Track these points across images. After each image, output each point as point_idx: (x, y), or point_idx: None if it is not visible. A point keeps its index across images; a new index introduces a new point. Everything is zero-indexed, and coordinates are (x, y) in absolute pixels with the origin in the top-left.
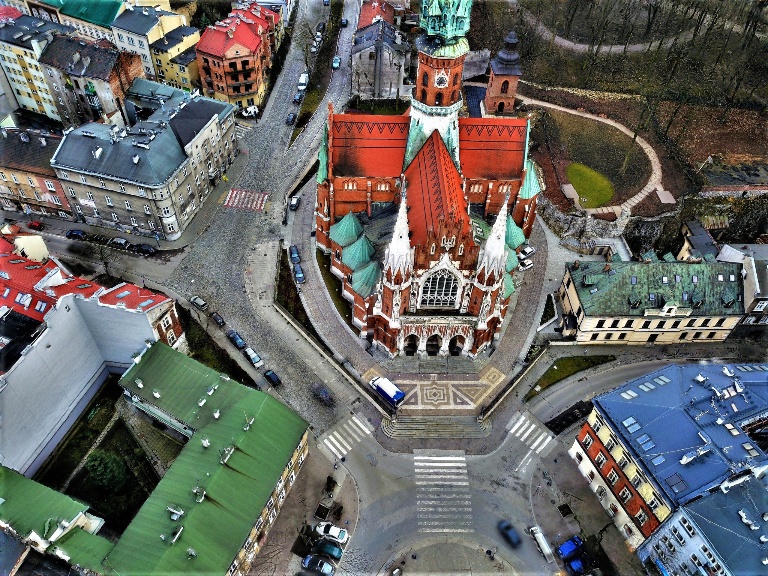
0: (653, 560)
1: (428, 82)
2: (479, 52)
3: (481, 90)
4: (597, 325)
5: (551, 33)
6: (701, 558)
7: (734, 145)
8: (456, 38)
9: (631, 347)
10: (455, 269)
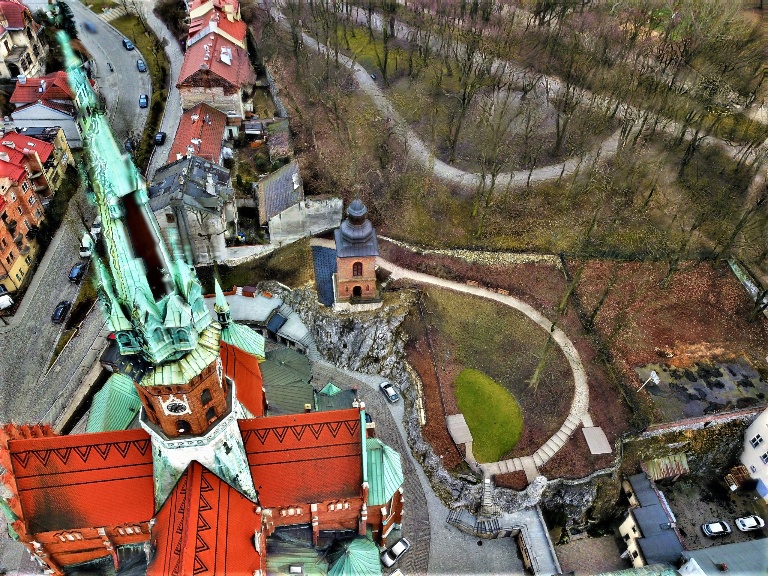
0: None
1: (153, 407)
2: (326, 202)
3: (334, 254)
4: None
5: None
6: None
7: (684, 327)
8: (180, 352)
9: None
10: None
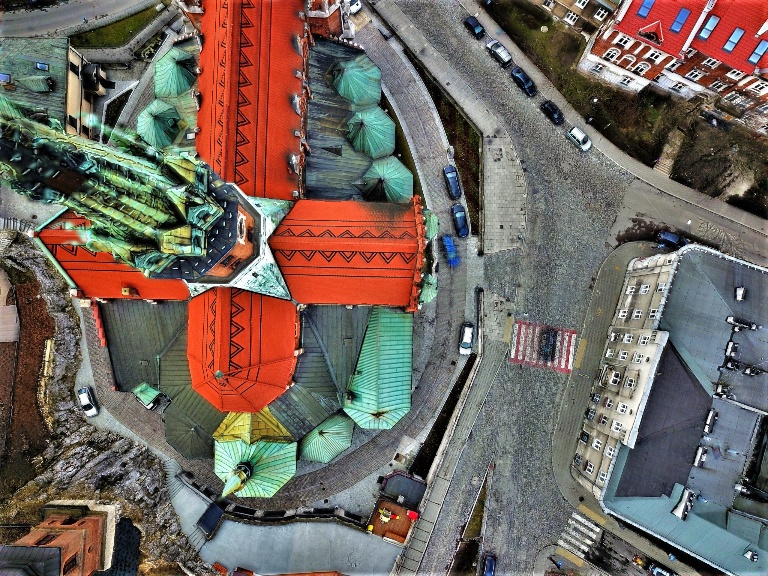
0: None
1: None
2: None
3: None
4: None
5: None
6: None
7: None
8: None
9: None
10: None
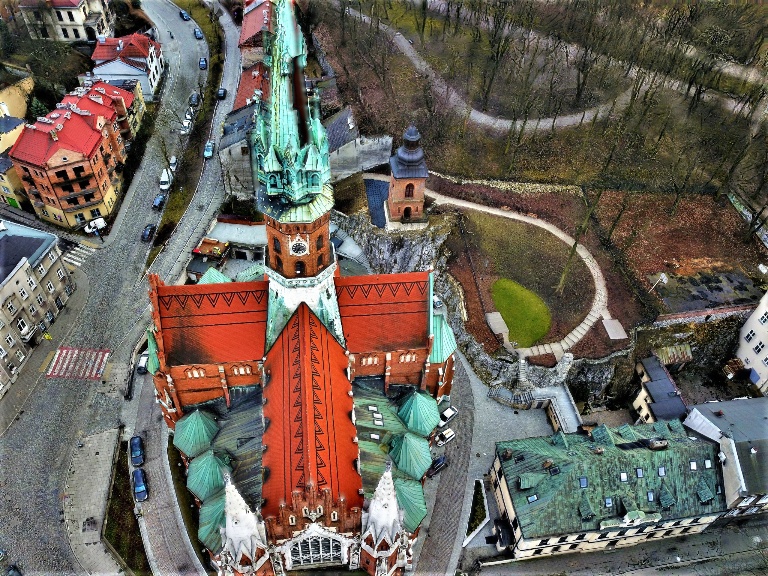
0: None
1: (281, 249)
2: (378, 139)
3: (384, 185)
4: (540, 542)
5: (466, 105)
6: None
7: (689, 245)
8: (310, 195)
9: (586, 556)
10: (330, 534)
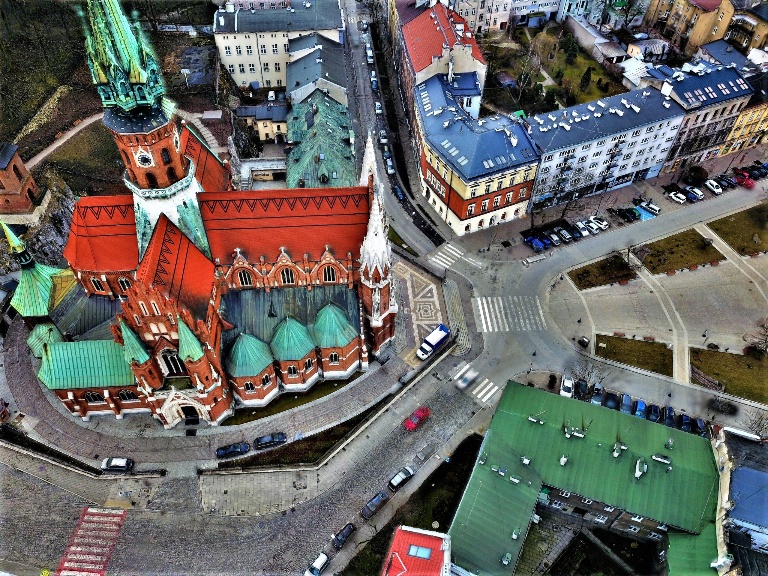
0: (537, 202)
1: (170, 156)
2: None
3: None
4: None
5: None
6: (561, 160)
7: None
8: None
9: None
10: None
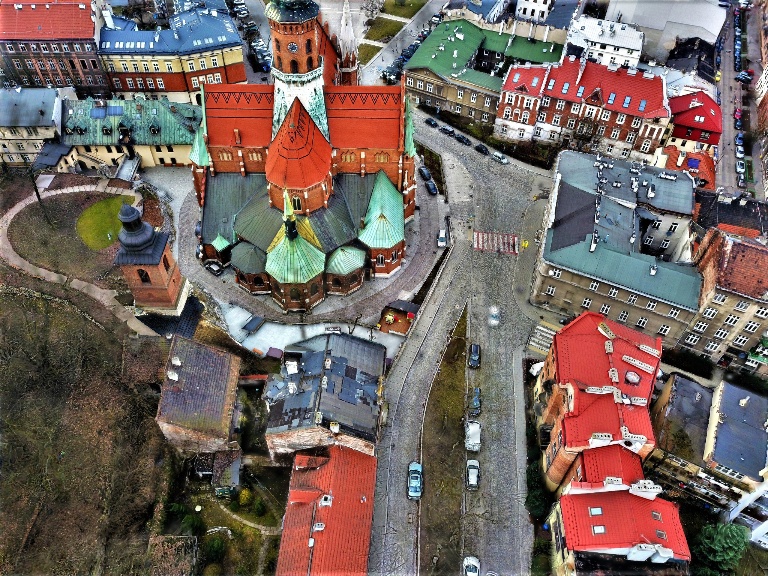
0: None
1: None
2: None
3: None
4: None
5: None
6: None
7: None
8: None
9: None
10: None
